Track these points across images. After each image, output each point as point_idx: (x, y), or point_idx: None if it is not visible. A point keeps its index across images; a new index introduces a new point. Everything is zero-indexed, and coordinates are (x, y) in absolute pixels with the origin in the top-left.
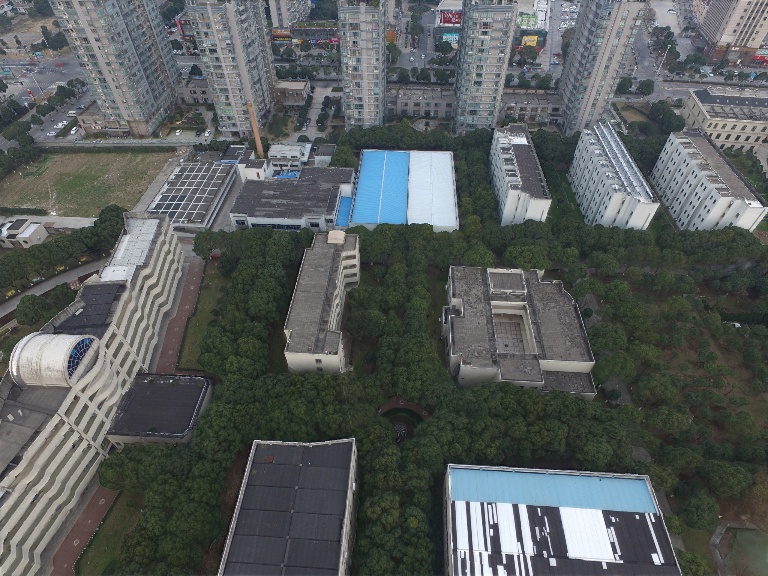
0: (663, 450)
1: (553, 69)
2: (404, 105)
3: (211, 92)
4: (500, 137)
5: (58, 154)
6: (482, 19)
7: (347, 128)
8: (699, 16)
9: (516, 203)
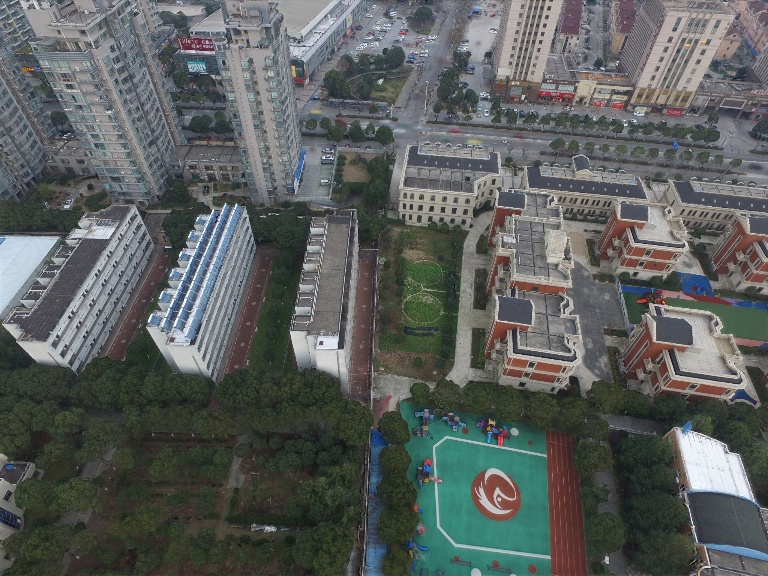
0: None
1: (308, 106)
2: (68, 162)
3: None
4: (85, 226)
5: None
6: (55, 69)
7: None
8: None
9: None
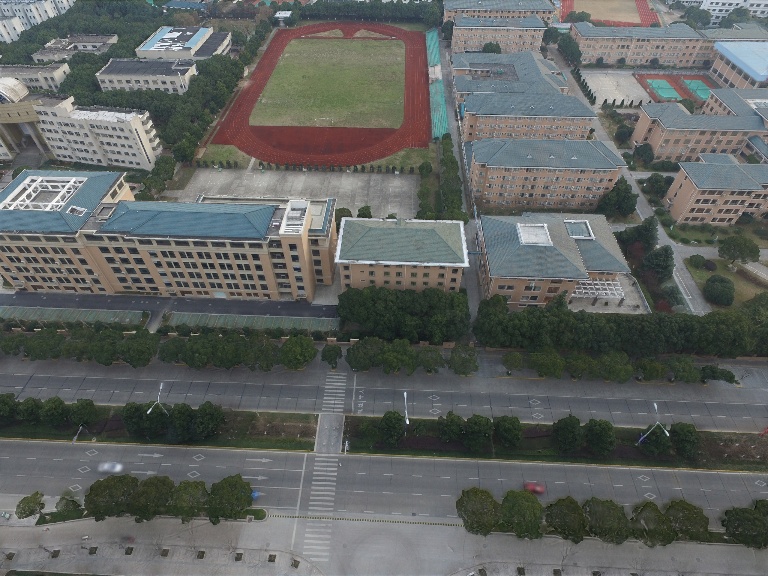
0: None
1: None
2: None
3: None
4: None
5: None
6: None
7: None
8: None
9: (5, 31)
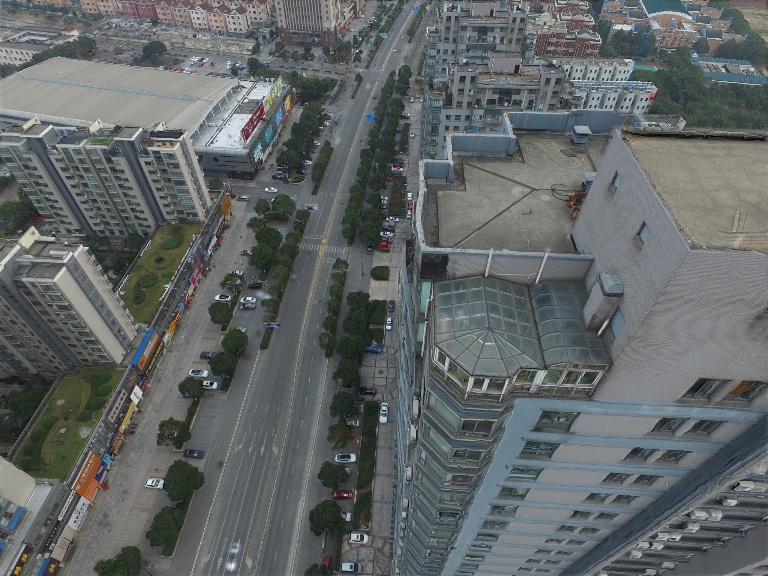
0: None
1: (331, 110)
2: None
3: None
4: None
5: None
6: None
7: None
8: (238, 26)
9: None
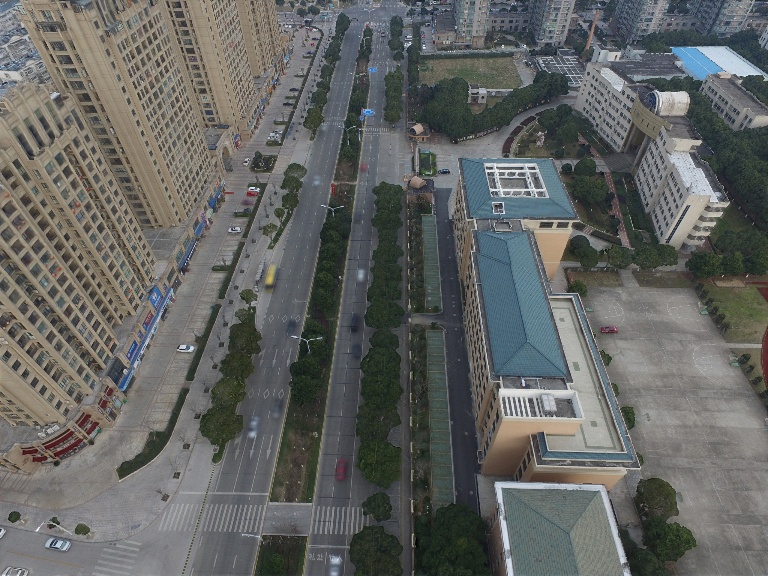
0: None
1: None
2: None
3: (546, 11)
4: None
5: (429, 60)
6: None
7: (633, 38)
8: None
9: None
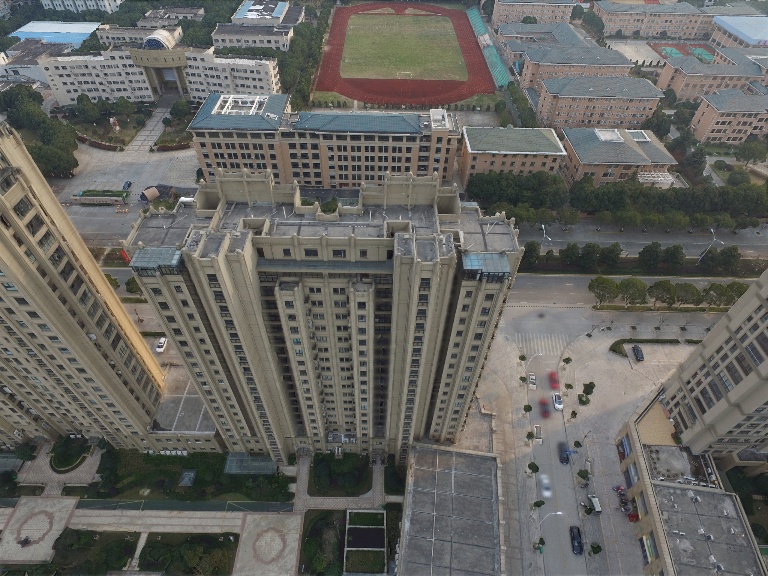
0: (237, 4)
1: None
2: None
3: None
4: None
5: None
6: None
7: None
8: None
9: (107, 2)
